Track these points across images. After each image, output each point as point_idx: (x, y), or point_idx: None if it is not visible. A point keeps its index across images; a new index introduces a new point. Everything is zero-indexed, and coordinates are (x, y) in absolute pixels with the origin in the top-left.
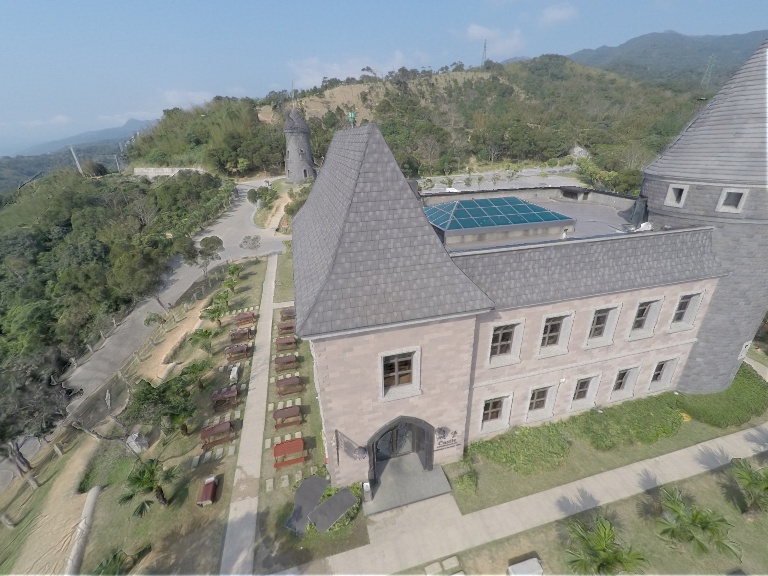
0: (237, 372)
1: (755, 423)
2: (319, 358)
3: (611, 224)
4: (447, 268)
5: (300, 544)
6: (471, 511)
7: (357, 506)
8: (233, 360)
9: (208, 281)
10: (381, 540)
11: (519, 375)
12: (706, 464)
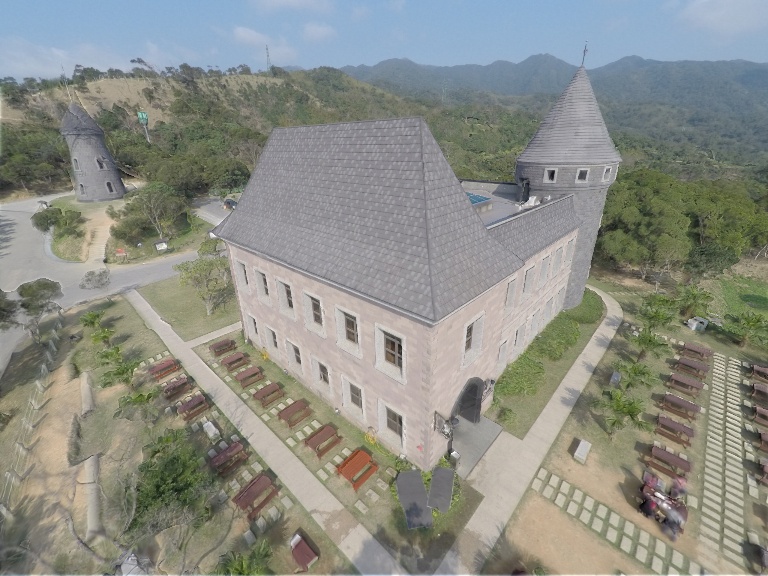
0: (215, 426)
1: (604, 315)
2: (433, 342)
3: (502, 202)
4: (490, 240)
5: (435, 533)
6: (525, 434)
7: (456, 475)
8: (191, 418)
9: (49, 343)
10: (490, 489)
11: (512, 321)
12: (604, 346)
